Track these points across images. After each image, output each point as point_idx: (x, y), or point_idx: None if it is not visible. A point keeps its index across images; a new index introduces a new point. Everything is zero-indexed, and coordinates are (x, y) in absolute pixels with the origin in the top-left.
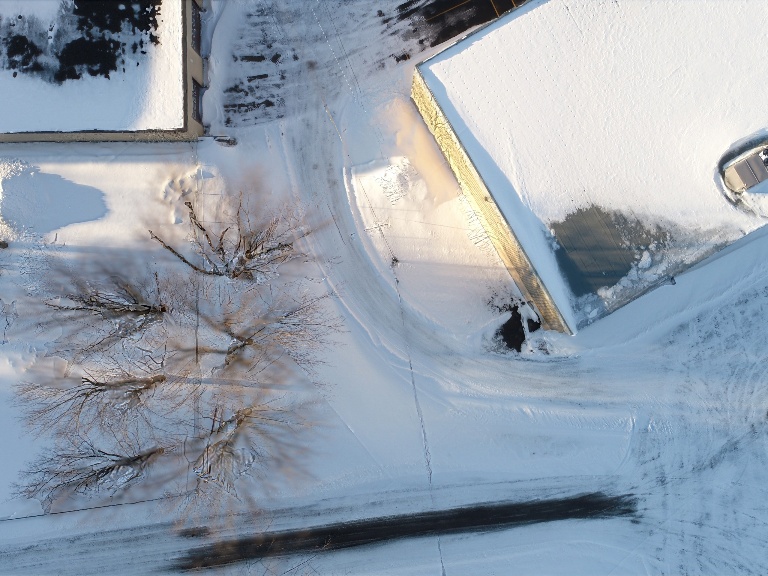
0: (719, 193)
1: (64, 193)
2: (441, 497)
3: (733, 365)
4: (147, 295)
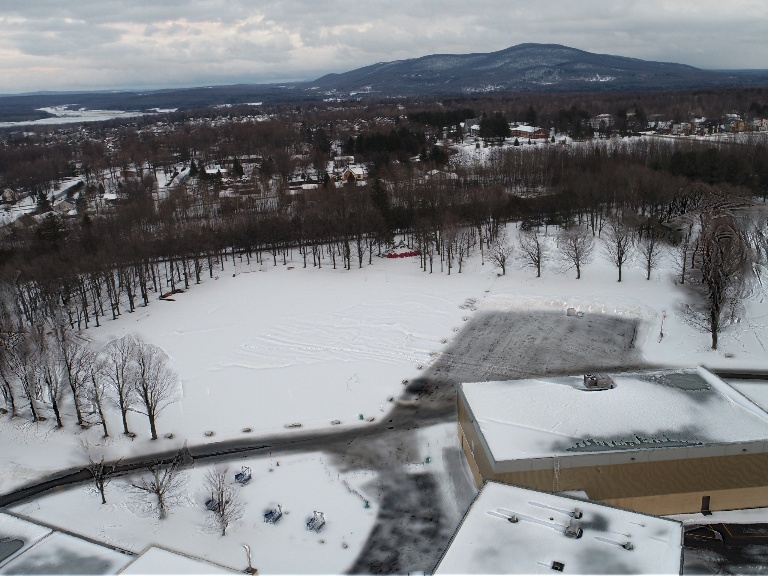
0: None
1: None
2: (759, 381)
3: None
4: None
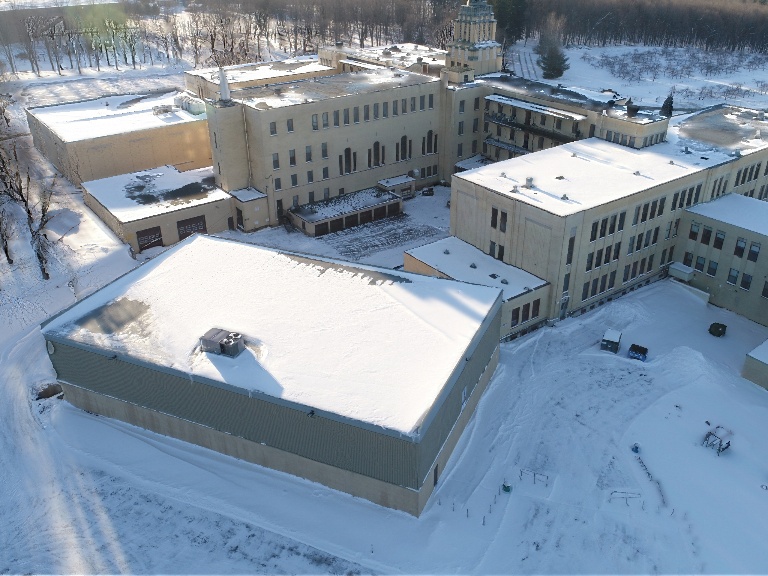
0: (196, 343)
1: (72, 226)
2: None
3: (75, 522)
4: (19, 259)
